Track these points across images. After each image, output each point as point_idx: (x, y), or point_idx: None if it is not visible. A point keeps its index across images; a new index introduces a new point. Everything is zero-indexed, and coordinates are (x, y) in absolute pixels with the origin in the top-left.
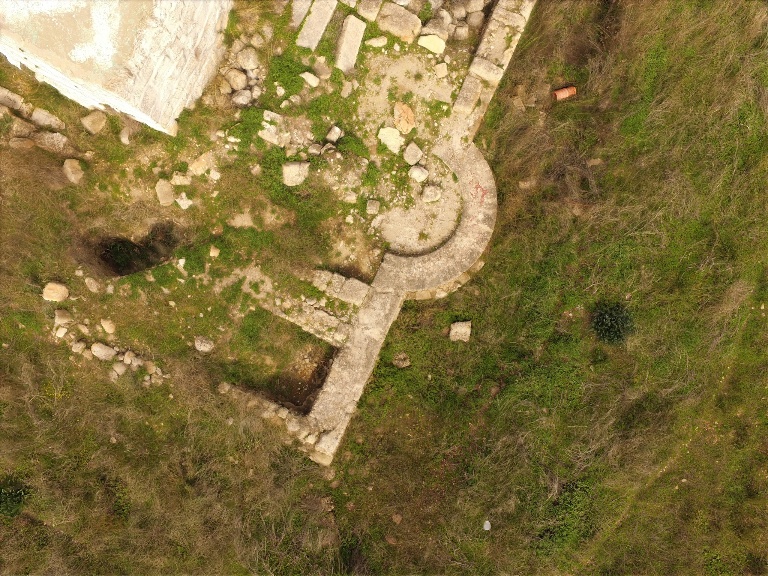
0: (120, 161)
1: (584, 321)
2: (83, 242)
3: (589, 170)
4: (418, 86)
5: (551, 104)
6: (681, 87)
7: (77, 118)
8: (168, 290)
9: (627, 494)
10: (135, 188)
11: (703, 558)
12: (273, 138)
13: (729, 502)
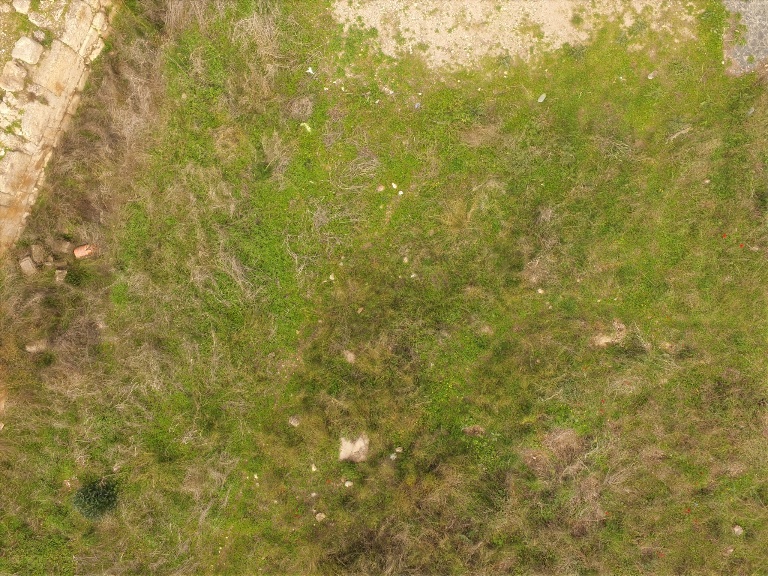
0: None
1: (75, 492)
2: None
3: (98, 333)
4: None
5: (73, 261)
6: (154, 259)
7: None
8: None
9: None
10: None
11: None
12: None
13: None
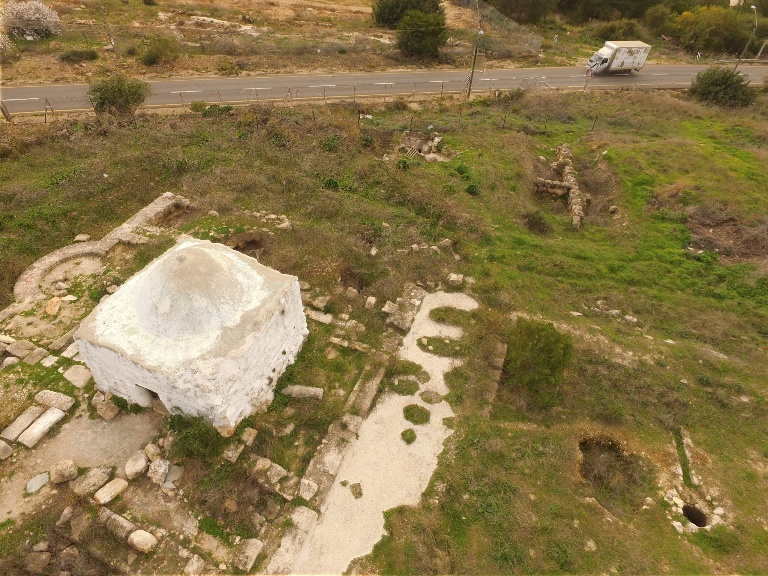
0: None
1: (5, 231)
2: None
3: None
4: (33, 320)
5: None
6: None
7: None
8: None
9: None
10: None
11: None
12: None
13: None
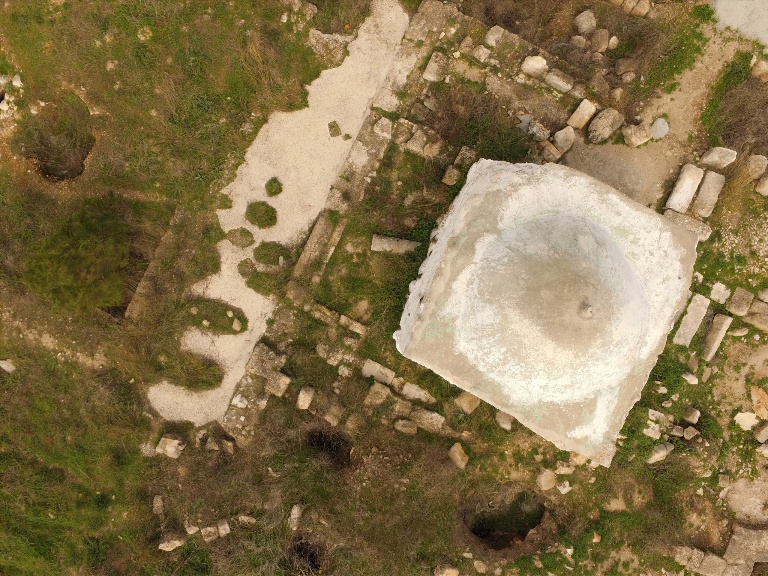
0: (498, 444)
1: None
2: (457, 515)
3: None
4: None
5: None
6: None
7: (451, 397)
8: (554, 575)
9: None
10: (515, 472)
11: None
12: (657, 436)
13: None
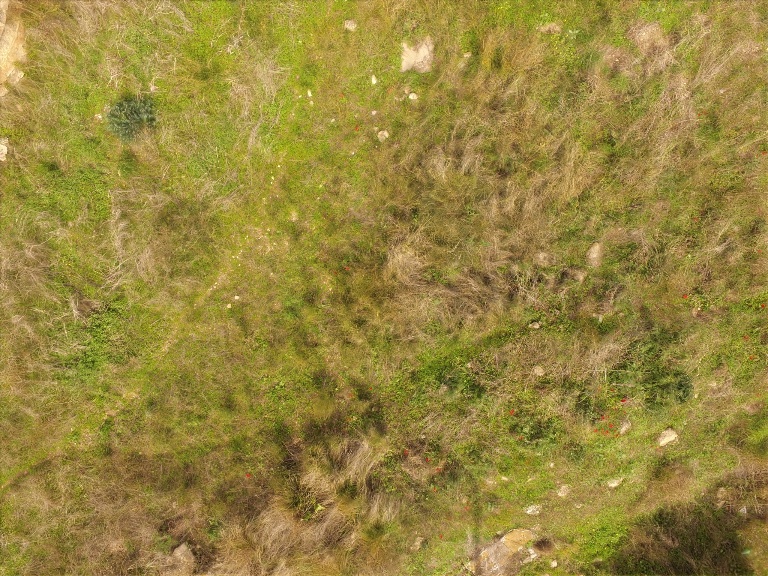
0: None
1: None
2: None
3: None
4: None
5: None
6: None
7: None
8: None
9: (170, 315)
10: None
11: (264, 385)
12: None
13: (288, 319)
